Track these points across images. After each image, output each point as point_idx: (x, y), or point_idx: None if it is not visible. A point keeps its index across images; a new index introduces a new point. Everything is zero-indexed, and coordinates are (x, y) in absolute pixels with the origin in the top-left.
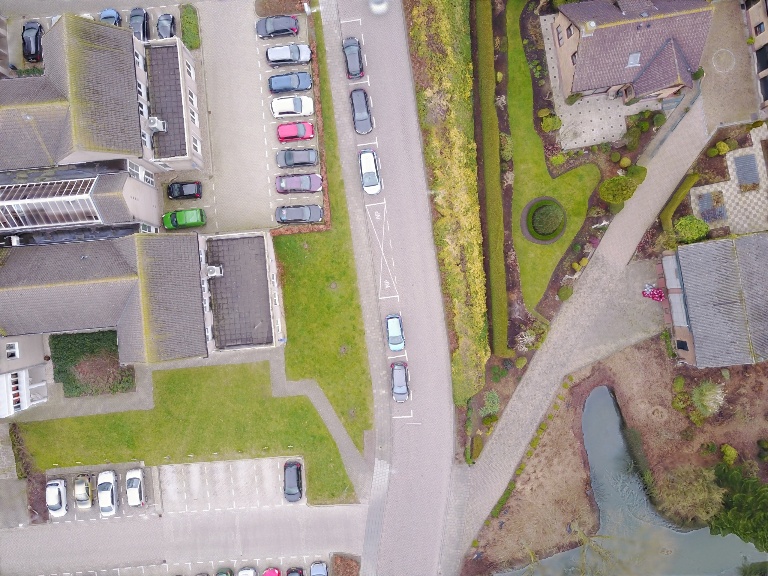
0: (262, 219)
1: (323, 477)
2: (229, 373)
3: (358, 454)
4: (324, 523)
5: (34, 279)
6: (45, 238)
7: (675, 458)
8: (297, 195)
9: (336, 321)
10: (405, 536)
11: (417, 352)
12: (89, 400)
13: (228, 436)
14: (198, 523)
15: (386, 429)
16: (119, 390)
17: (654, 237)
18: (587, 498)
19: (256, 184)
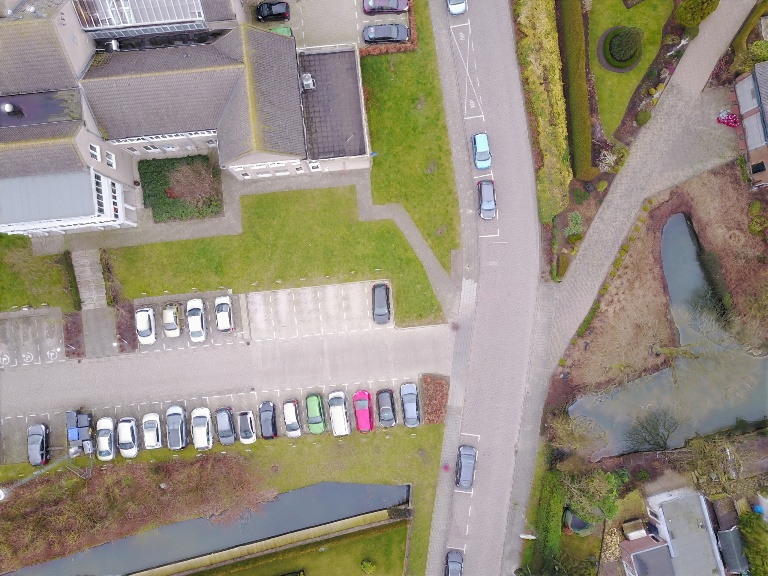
0: (349, 41)
1: (411, 299)
2: (316, 197)
3: (445, 274)
4: (412, 345)
5: (141, 70)
6: (144, 44)
7: (753, 281)
8: (383, 17)
9: (422, 143)
10: (493, 355)
11: (503, 171)
12: (178, 226)
13: (316, 261)
14: (286, 350)
15: (473, 248)
16: (208, 215)
17: (727, 64)
18: (668, 322)
19: (343, 7)
